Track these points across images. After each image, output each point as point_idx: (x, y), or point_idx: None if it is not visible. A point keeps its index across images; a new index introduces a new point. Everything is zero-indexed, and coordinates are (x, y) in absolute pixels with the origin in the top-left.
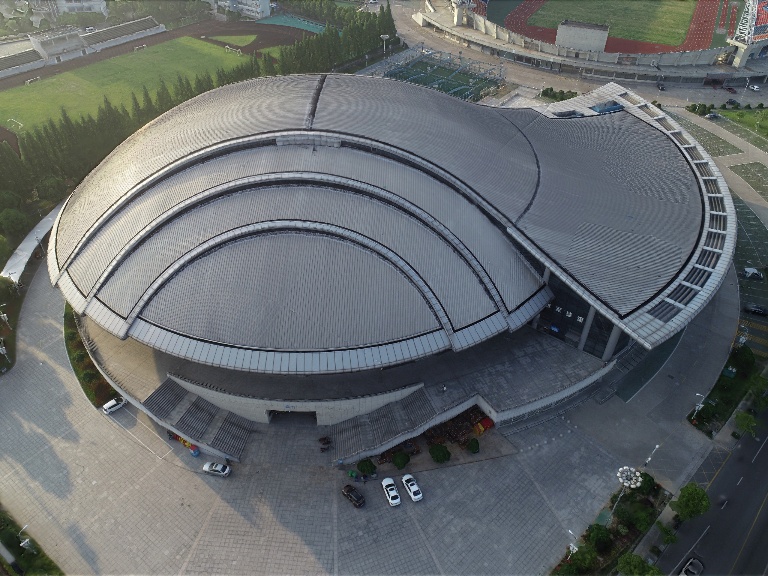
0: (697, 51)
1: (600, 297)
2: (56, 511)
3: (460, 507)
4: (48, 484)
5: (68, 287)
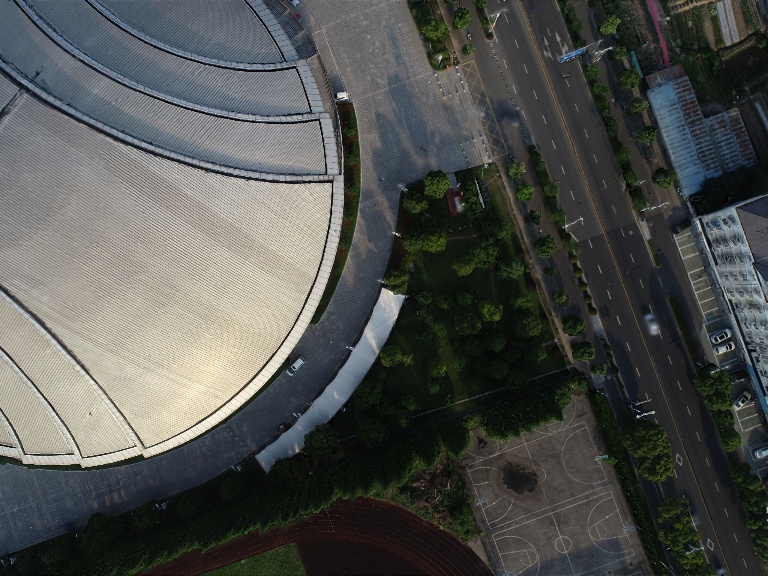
0: None
1: None
2: (395, 28)
3: None
4: (396, 52)
5: (331, 152)
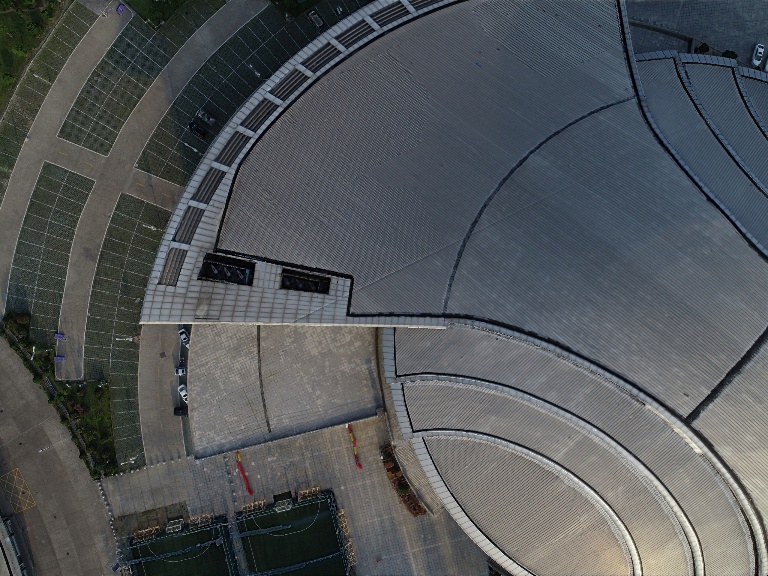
0: None
1: (616, 5)
2: None
3: (739, 24)
4: None
5: None
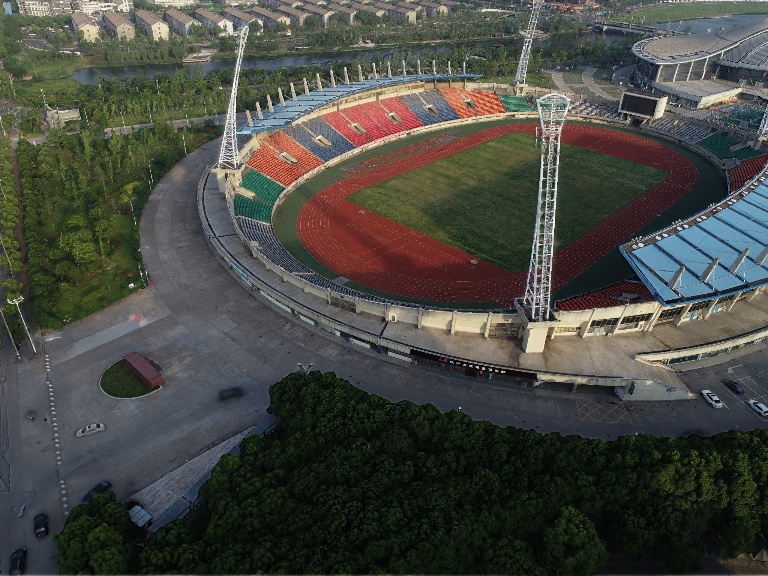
0: (555, 90)
1: None
2: None
3: None
4: None
5: None
